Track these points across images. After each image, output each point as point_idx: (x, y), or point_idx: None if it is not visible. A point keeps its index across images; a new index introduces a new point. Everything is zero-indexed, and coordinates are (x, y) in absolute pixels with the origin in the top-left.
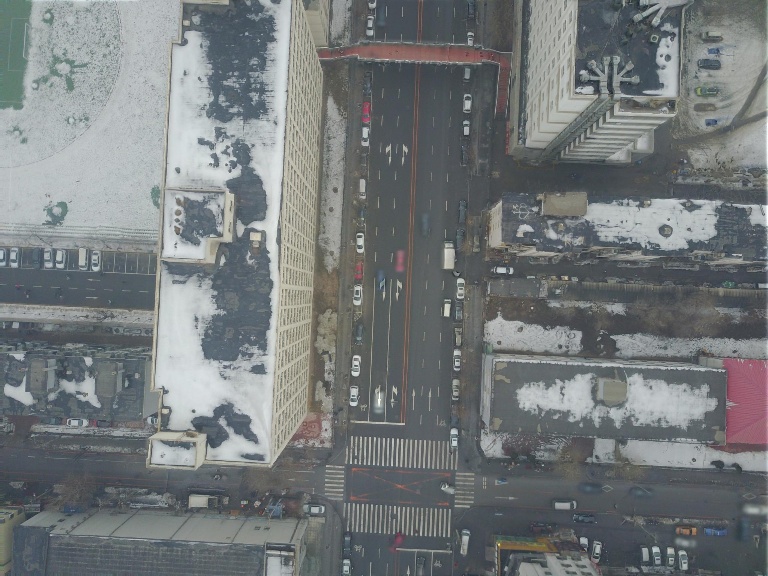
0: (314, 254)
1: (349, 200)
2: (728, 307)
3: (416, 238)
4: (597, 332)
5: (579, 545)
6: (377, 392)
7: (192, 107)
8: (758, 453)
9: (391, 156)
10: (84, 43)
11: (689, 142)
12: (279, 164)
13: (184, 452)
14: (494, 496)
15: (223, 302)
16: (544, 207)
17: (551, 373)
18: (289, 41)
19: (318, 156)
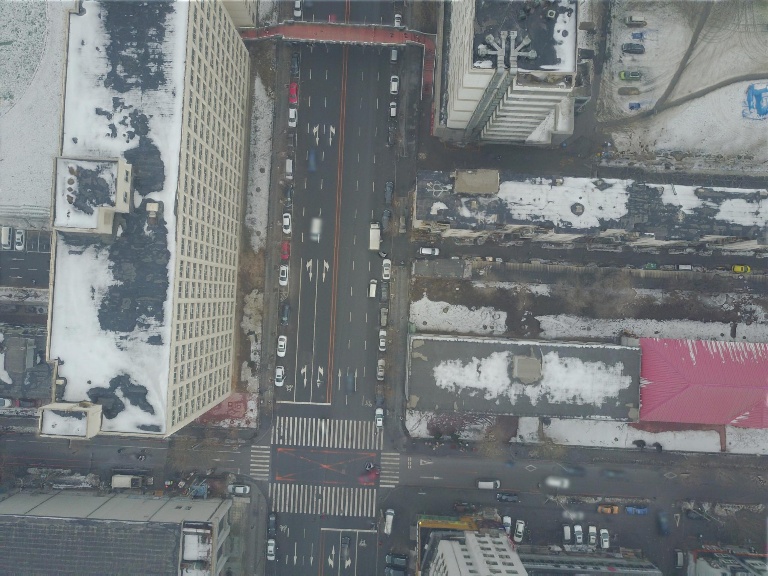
0: (239, 234)
1: (276, 180)
2: (649, 288)
3: (343, 219)
4: (521, 313)
5: (499, 523)
6: (303, 372)
7: (90, 77)
8: (679, 432)
9: (319, 137)
10: (9, 21)
11: (613, 125)
12: (177, 135)
13: (76, 422)
14: (419, 476)
15: (120, 273)
16: (456, 184)
17: (468, 351)
18: (188, 12)
19: (243, 135)
